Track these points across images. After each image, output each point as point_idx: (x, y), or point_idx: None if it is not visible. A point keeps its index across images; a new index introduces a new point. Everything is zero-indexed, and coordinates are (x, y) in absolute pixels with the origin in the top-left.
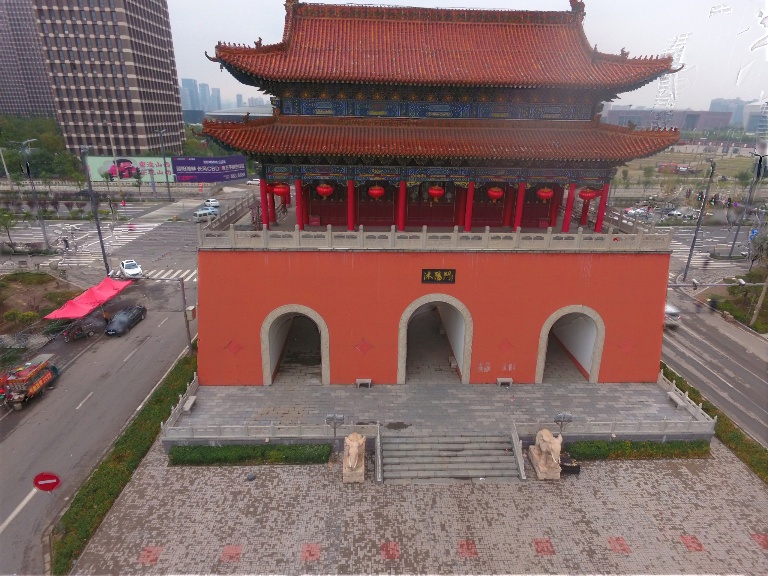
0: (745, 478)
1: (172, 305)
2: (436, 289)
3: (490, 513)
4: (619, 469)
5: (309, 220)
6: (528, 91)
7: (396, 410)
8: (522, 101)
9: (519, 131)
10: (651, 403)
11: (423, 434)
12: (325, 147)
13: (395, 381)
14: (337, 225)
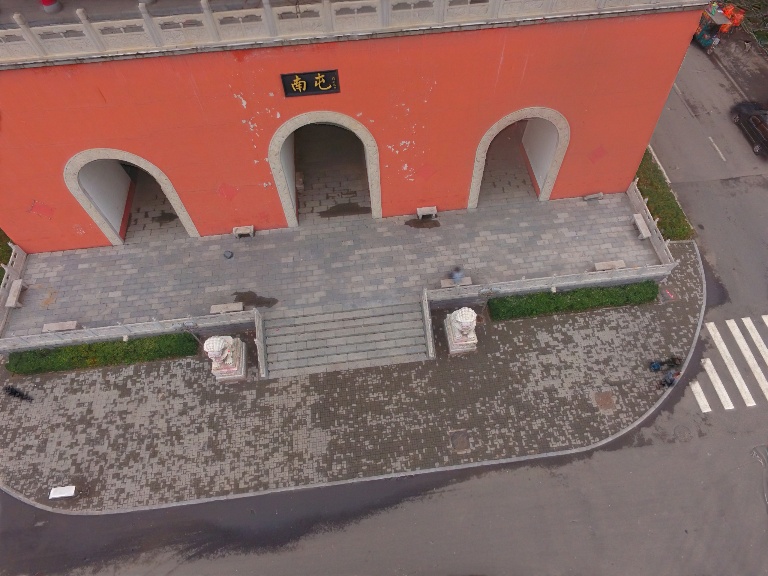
0: None
1: (764, 197)
2: None
3: None
4: None
5: None
6: None
7: None
8: None
9: None
10: None
11: None
12: None
13: None
14: None
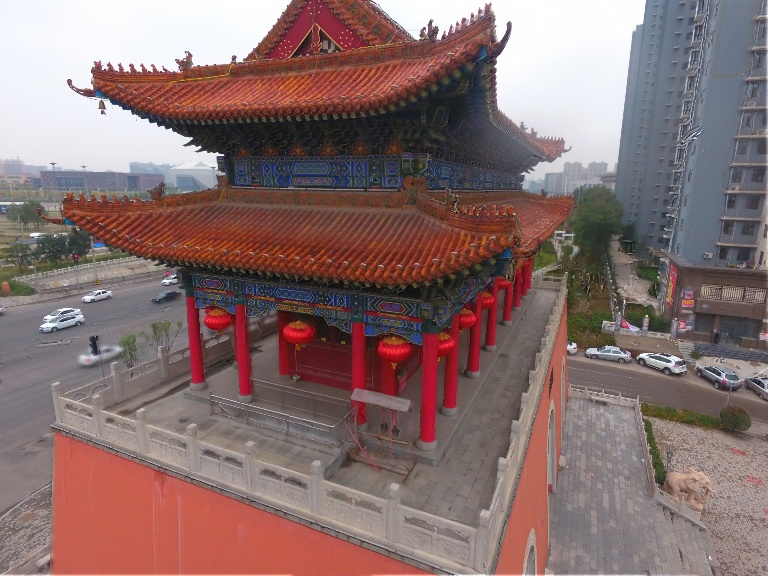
0: (672, 425)
1: None
2: (550, 399)
3: (765, 575)
4: (673, 469)
5: (399, 385)
6: (519, 161)
7: (614, 573)
8: (507, 171)
9: (512, 202)
10: (599, 411)
11: (667, 567)
12: (527, 244)
13: (547, 547)
14: (412, 375)
